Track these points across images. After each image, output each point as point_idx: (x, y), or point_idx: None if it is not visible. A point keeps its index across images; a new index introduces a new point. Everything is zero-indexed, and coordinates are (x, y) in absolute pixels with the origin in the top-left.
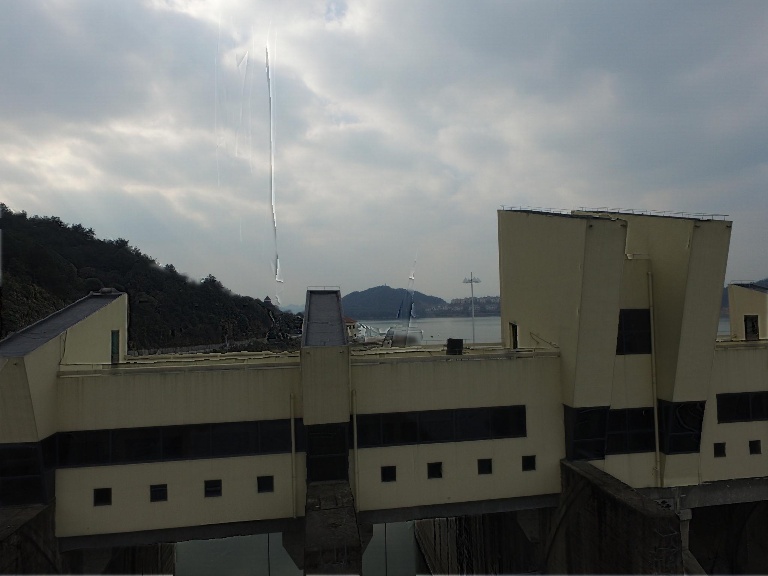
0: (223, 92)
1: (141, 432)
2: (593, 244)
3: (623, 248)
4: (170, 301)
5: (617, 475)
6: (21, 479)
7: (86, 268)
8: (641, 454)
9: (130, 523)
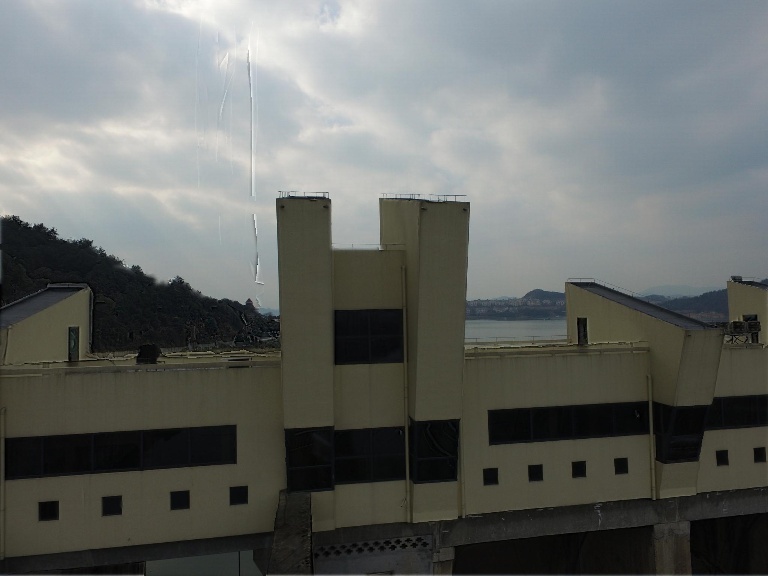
0: (204, 92)
1: None
2: (290, 229)
3: (330, 235)
4: (130, 303)
5: (356, 508)
6: None
7: (41, 269)
8: (388, 483)
9: None
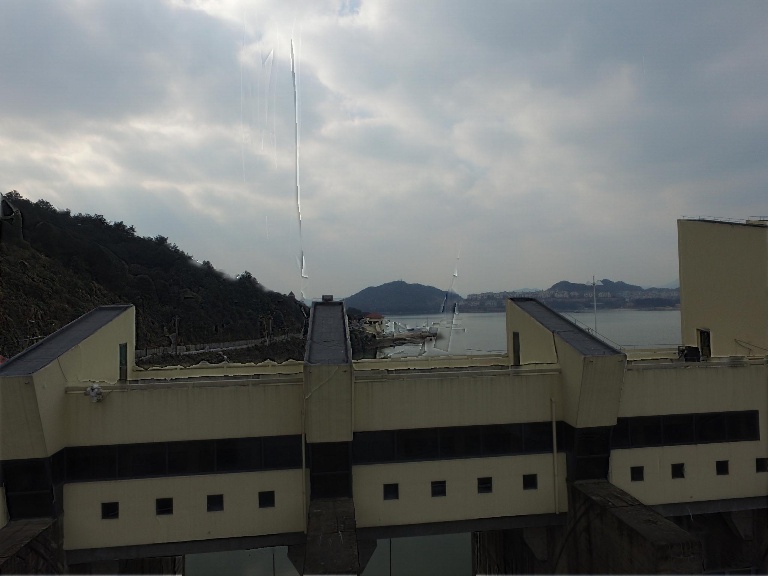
0: (248, 89)
1: (421, 433)
2: None
3: None
4: (212, 297)
5: None
6: (332, 475)
7: (133, 265)
8: None
9: (414, 516)
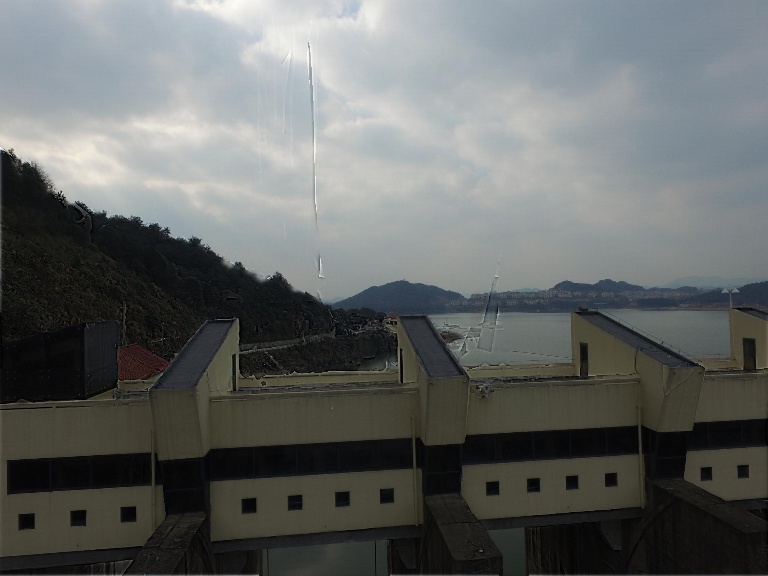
0: (265, 90)
1: (728, 424)
2: None
3: None
4: (250, 298)
5: None
6: (671, 459)
7: None
8: None
9: (725, 494)
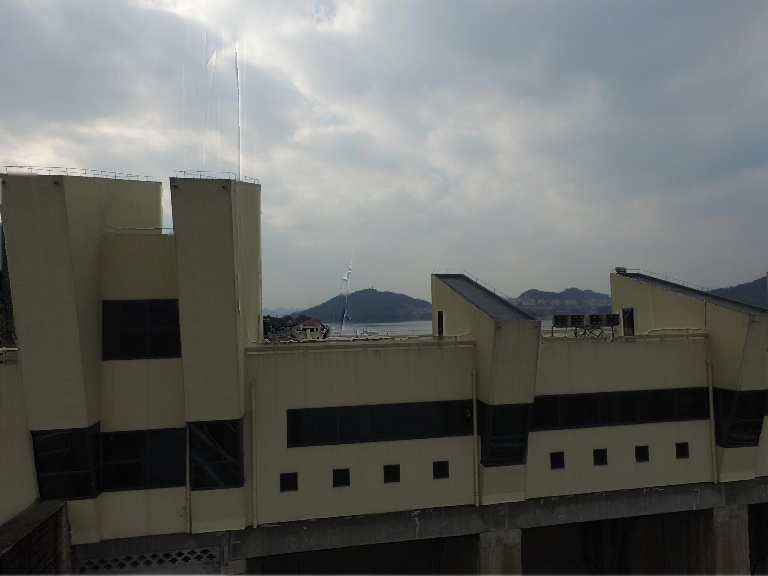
0: (192, 91)
1: None
2: (17, 208)
3: (65, 214)
4: None
5: (128, 518)
6: None
7: None
8: (166, 489)
9: None
